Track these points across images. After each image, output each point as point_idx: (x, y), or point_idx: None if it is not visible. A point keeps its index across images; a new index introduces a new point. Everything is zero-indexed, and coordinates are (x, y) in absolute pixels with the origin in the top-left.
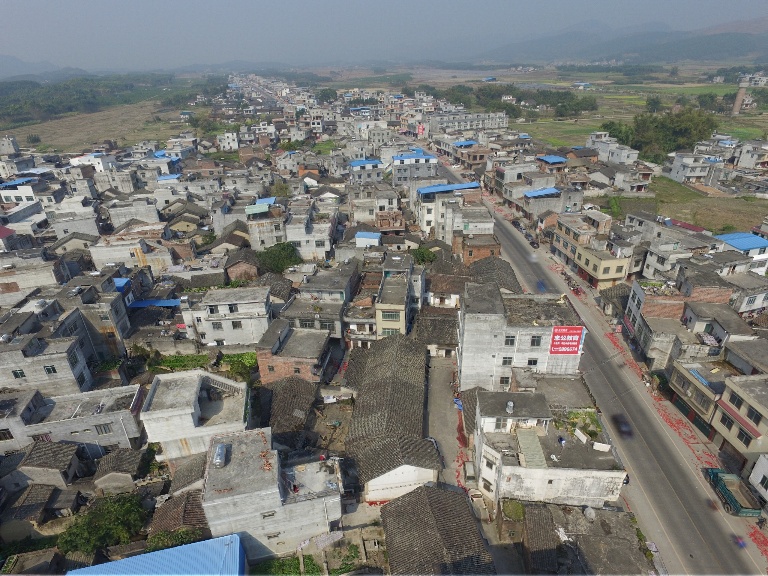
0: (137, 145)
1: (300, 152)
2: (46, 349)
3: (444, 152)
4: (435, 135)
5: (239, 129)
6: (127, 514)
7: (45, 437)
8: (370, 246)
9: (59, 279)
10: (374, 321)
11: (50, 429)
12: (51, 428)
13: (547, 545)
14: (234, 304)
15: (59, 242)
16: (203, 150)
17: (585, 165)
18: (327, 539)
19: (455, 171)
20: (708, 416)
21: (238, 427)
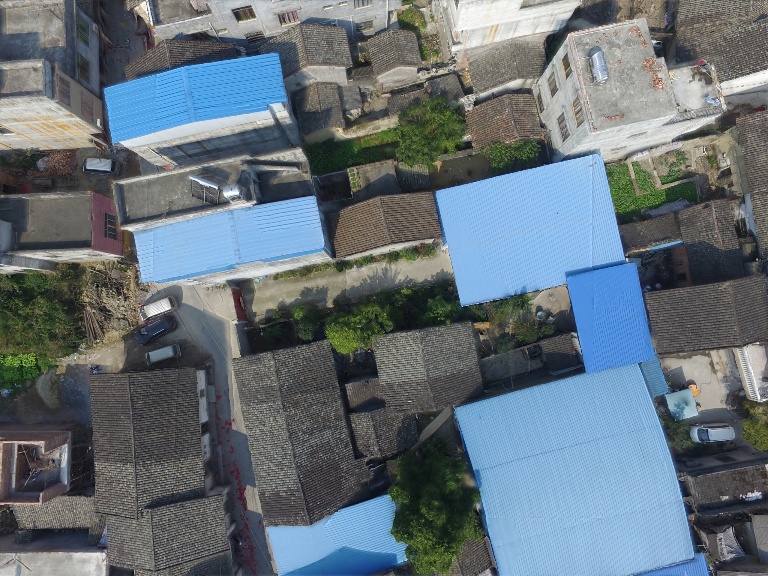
0: None
1: None
2: None
3: None
4: None
5: None
6: (450, 123)
7: (291, 14)
8: None
9: None
10: None
11: (300, 4)
12: (301, 2)
13: None
14: None
15: None
16: None
17: None
18: (666, 150)
19: None
20: None
21: (569, 7)
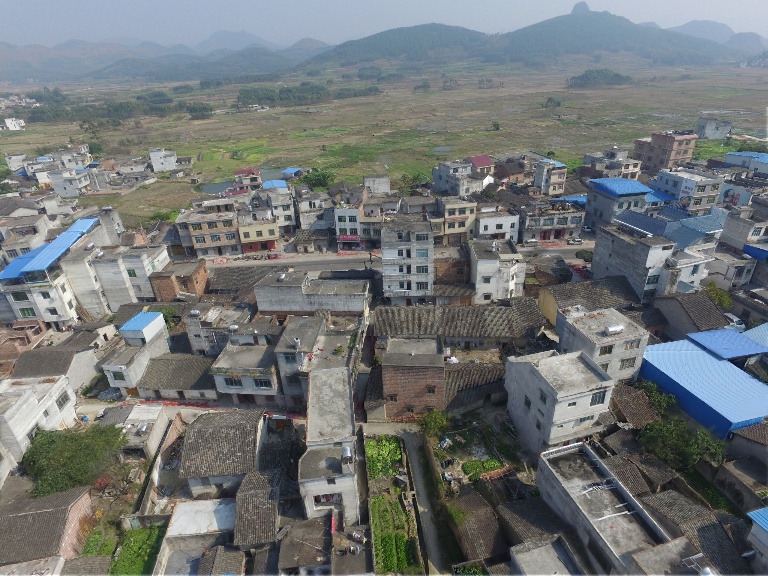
0: None
1: None
2: None
3: None
4: None
5: None
6: None
7: None
8: None
9: None
10: (364, 315)
11: None
12: None
13: (551, 271)
14: None
15: None
16: None
17: None
18: None
19: None
20: (442, 231)
21: None
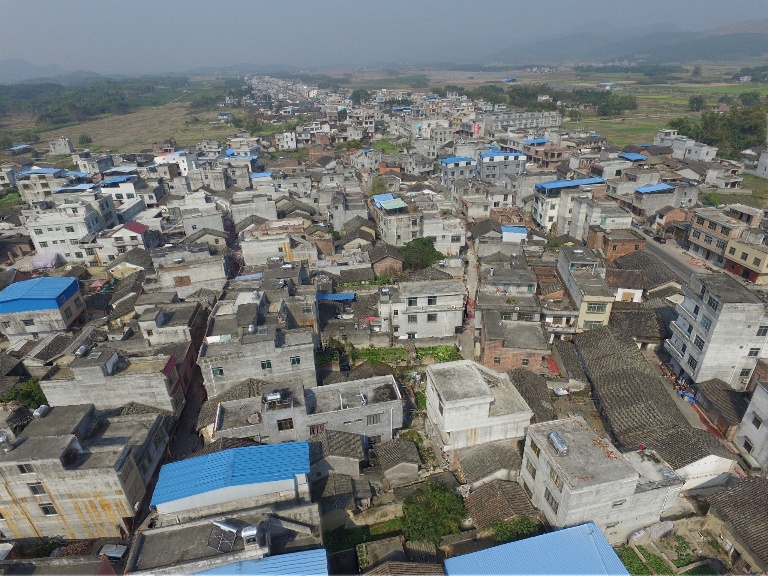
0: (200, 144)
1: (375, 150)
2: (286, 340)
3: (510, 150)
4: (497, 134)
5: (295, 129)
6: (450, 503)
7: (320, 427)
8: (528, 240)
9: (225, 273)
10: (577, 313)
11: (327, 419)
12: (328, 418)
13: None
14: (434, 296)
15: (191, 238)
16: (263, 149)
17: (664, 162)
18: (660, 529)
19: (531, 169)
20: None
21: (525, 417)
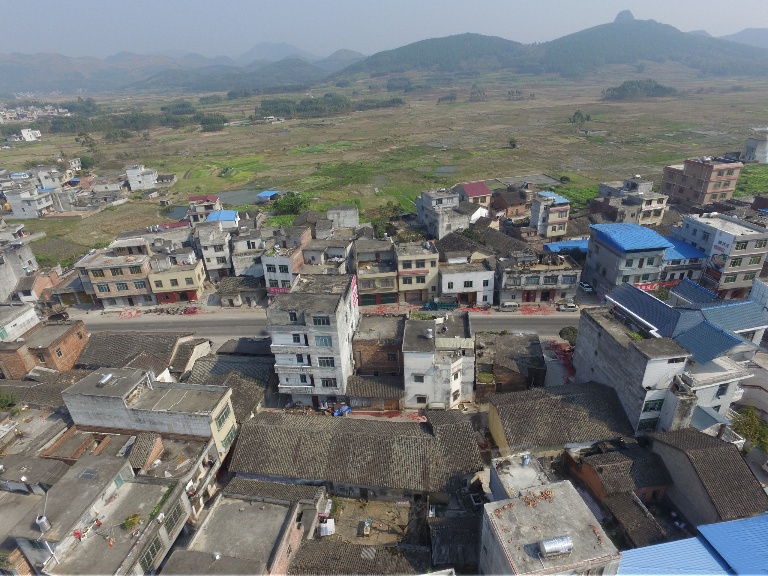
0: None
1: None
2: None
3: None
4: None
5: None
6: None
7: None
8: None
9: None
10: (212, 442)
11: None
12: None
13: (515, 364)
14: None
15: None
16: None
17: None
18: None
19: None
20: (396, 288)
21: None
